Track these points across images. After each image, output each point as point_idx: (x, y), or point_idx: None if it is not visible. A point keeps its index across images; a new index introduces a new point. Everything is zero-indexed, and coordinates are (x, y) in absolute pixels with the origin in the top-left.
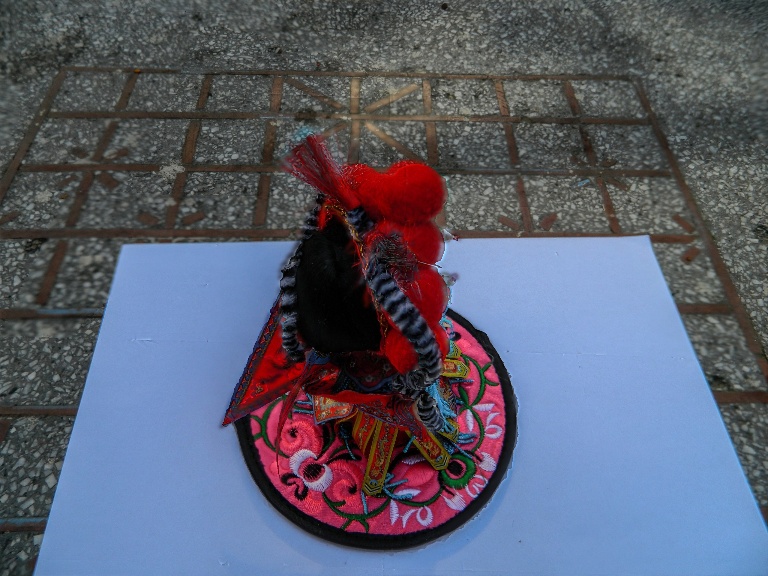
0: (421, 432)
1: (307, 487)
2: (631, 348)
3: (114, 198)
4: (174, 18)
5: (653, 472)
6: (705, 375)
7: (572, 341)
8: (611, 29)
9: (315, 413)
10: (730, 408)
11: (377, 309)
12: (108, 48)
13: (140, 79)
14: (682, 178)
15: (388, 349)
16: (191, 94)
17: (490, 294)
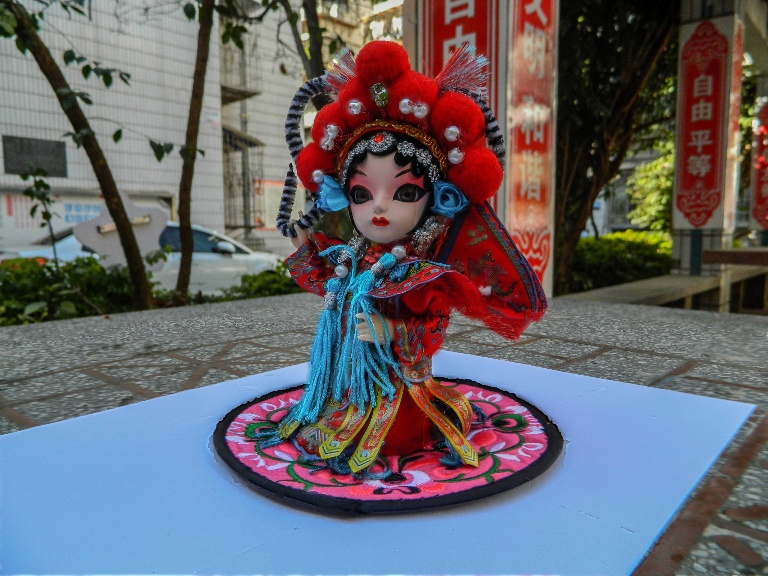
0: None
1: None
2: None
3: None
4: None
5: None
6: None
7: None
8: None
9: None
10: None
11: None
12: None
13: None
14: None
15: None
16: None
17: (405, 574)
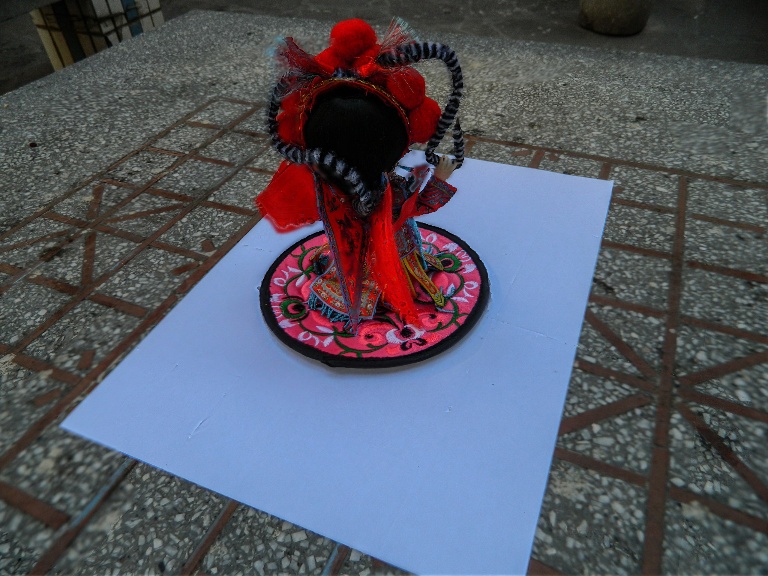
0: (449, 190)
1: (418, 338)
2: None
3: None
4: None
5: (491, 192)
6: (447, 154)
7: None
8: (164, 90)
9: (363, 315)
10: (471, 155)
11: (398, 104)
12: None
13: None
14: None
15: (419, 124)
16: None
17: None
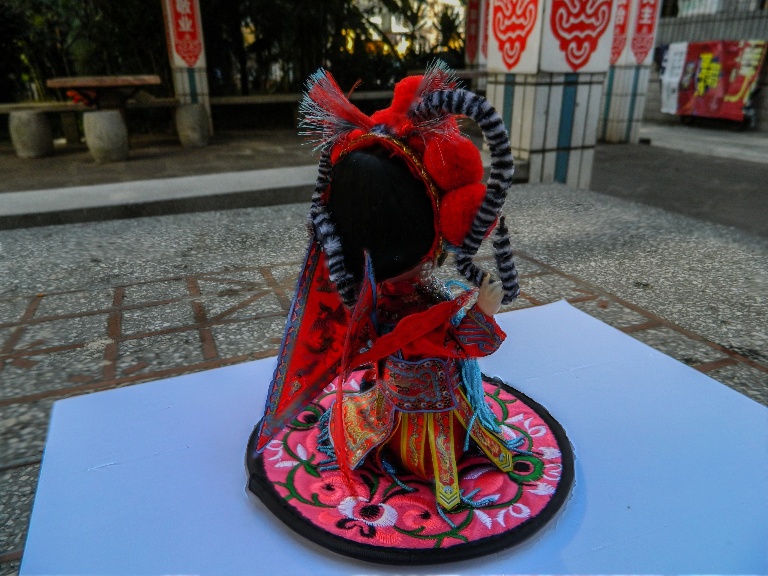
0: (494, 332)
1: (372, 525)
2: (607, 358)
3: (34, 373)
4: (72, 264)
5: (696, 424)
6: (677, 360)
7: (556, 364)
8: None
9: (347, 460)
10: (714, 373)
11: (426, 178)
12: (3, 288)
13: (45, 299)
14: (561, 273)
15: (447, 211)
16: (104, 299)
17: None
